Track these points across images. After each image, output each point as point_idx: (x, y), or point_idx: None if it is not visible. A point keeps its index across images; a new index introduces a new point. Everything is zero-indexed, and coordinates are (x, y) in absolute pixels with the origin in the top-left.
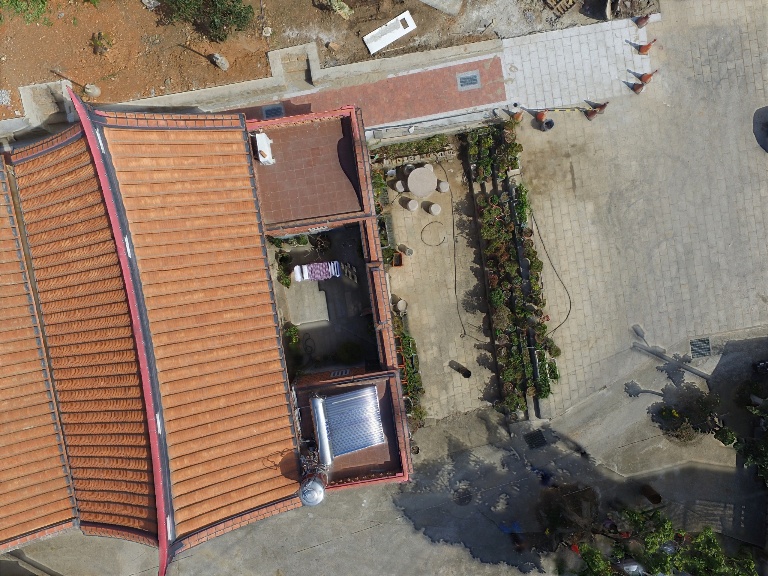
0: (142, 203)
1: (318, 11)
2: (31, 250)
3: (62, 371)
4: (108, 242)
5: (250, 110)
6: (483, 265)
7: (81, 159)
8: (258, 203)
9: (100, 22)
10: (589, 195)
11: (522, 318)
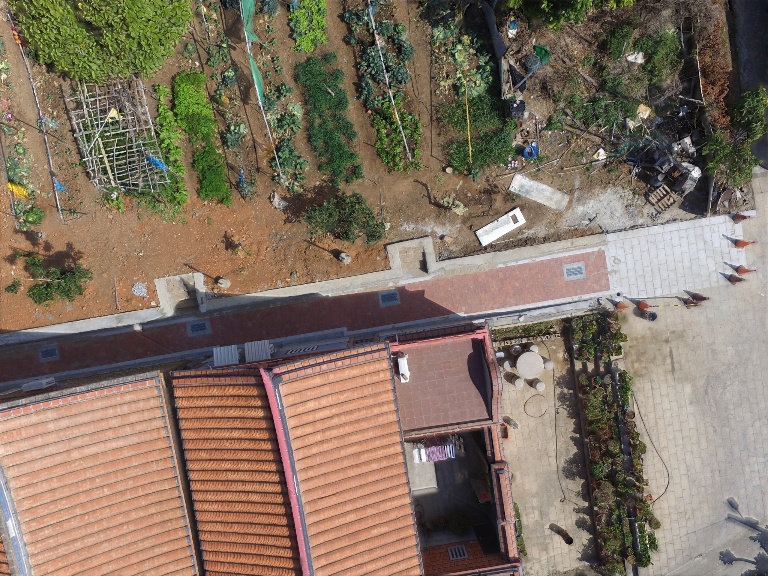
0: (306, 441)
1: (434, 208)
2: (188, 463)
3: (216, 575)
4: (272, 474)
5: (366, 295)
6: (583, 435)
7: (251, 402)
8: (400, 422)
9: (232, 221)
10: (687, 378)
11: (624, 493)
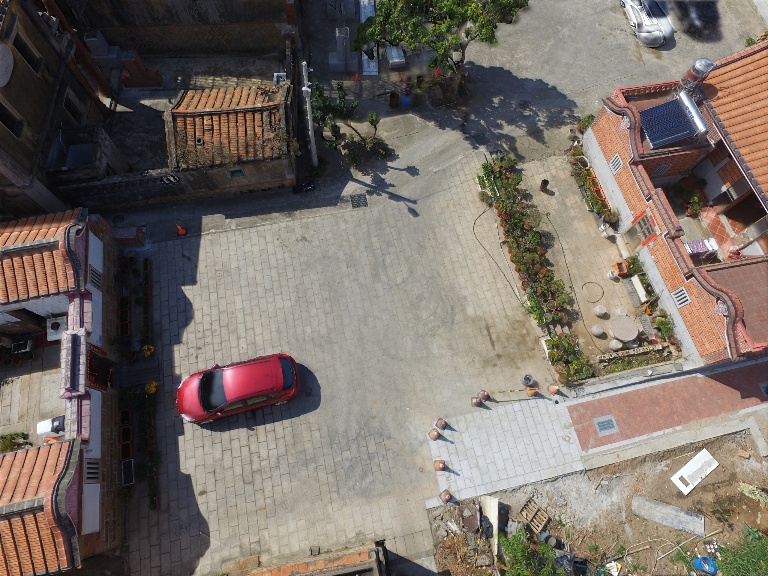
0: None
1: None
2: None
3: None
4: None
5: None
6: None
7: None
8: None
9: None
10: (473, 321)
11: None
